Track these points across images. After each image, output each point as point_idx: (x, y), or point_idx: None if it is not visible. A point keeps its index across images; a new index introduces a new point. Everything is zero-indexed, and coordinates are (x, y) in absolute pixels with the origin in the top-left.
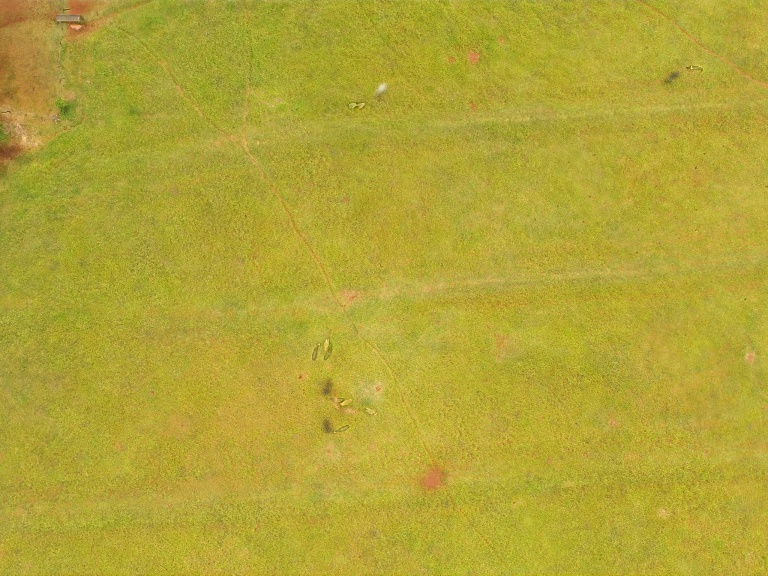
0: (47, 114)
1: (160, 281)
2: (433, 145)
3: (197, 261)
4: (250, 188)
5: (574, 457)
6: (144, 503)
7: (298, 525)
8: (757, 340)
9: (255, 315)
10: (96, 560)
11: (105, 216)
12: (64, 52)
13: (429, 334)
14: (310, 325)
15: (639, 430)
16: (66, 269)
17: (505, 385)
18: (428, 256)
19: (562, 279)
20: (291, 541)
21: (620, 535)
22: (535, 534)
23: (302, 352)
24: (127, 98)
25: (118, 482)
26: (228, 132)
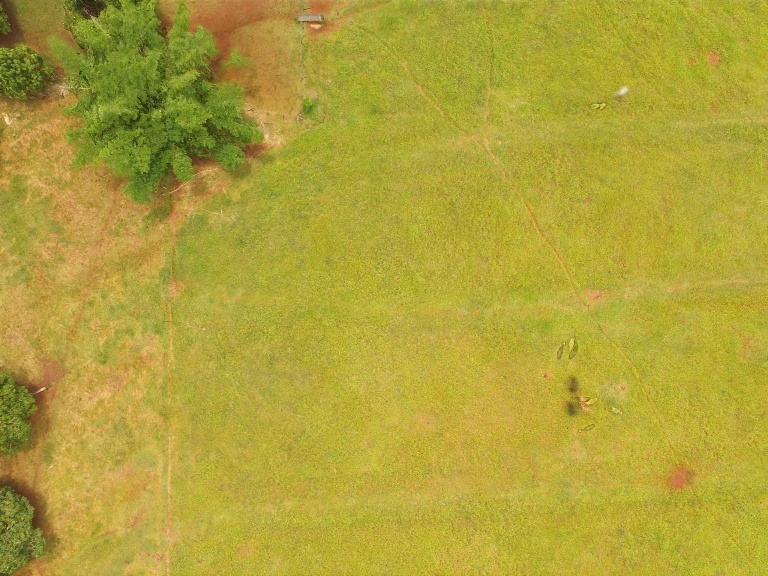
0: (289, 113)
1: (405, 279)
2: (674, 146)
3: (441, 260)
4: (493, 187)
5: None
6: (393, 500)
7: (546, 523)
8: None
9: (501, 314)
10: (346, 556)
11: (349, 214)
12: (306, 51)
13: (674, 334)
14: (555, 324)
15: None
16: (312, 267)
17: (751, 385)
18: (671, 256)
19: None
20: (539, 539)
21: None
22: None
23: (547, 351)
24: (369, 97)
25: (365, 479)
26: (470, 132)
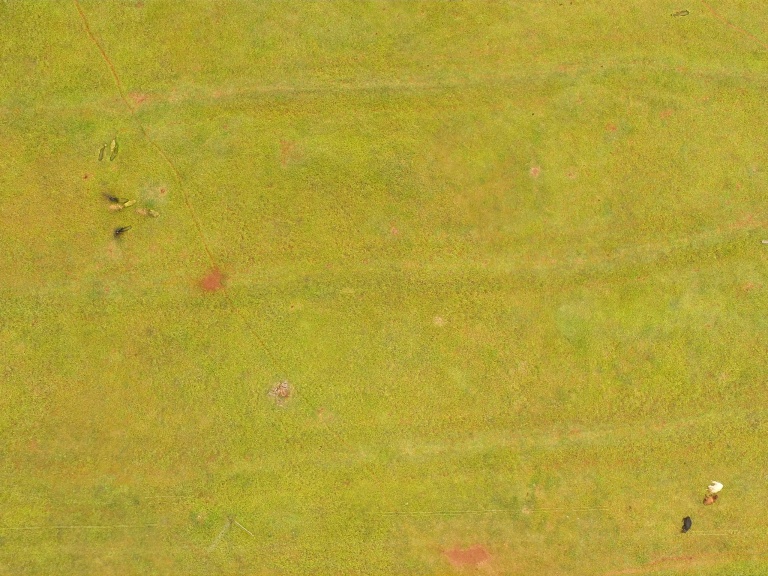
0: None
1: None
2: None
3: None
4: None
5: (354, 263)
6: None
7: (75, 321)
8: (542, 154)
9: (42, 113)
10: None
11: None
12: None
13: (215, 138)
14: (97, 125)
15: (421, 239)
16: None
17: (289, 190)
18: (219, 62)
19: (351, 89)
20: (68, 337)
21: (395, 341)
22: (311, 338)
23: (88, 152)
24: None
25: None
26: None
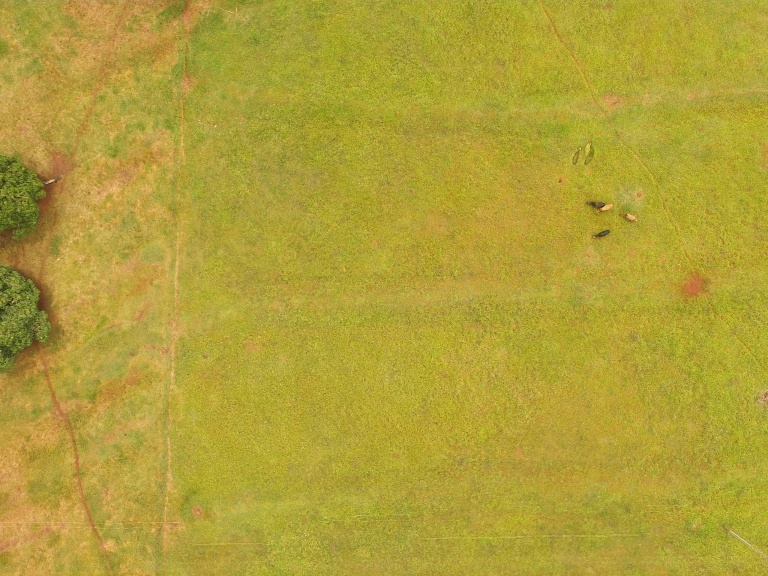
0: None
1: (420, 81)
2: None
3: (457, 63)
4: None
5: None
6: (402, 300)
7: (558, 327)
8: None
9: (517, 117)
10: (353, 355)
11: (365, 15)
12: None
13: (693, 141)
14: (572, 129)
15: None
16: (326, 66)
17: None
18: (691, 65)
19: None
20: (550, 343)
21: None
22: None
23: (563, 156)
24: None
25: (375, 279)
26: None
